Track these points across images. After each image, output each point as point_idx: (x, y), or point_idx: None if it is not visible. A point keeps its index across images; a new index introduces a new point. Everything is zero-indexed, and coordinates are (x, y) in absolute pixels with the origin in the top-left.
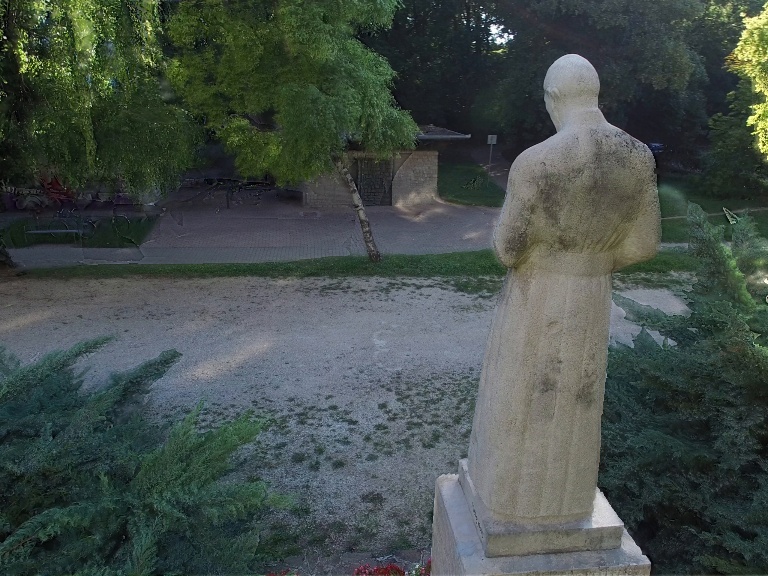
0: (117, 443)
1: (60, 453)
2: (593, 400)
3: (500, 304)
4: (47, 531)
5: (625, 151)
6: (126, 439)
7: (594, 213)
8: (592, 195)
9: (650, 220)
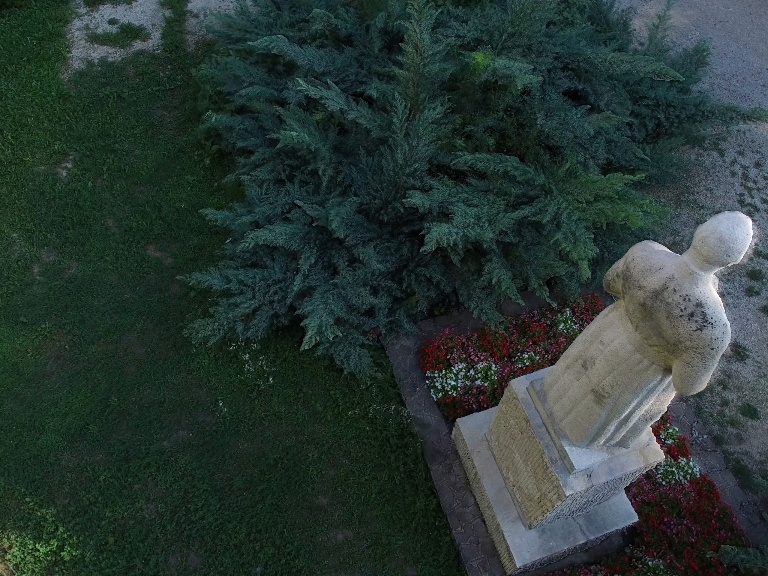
0: (648, 146)
1: (549, 132)
2: (601, 404)
3: None
4: (497, 166)
5: (676, 311)
6: (658, 148)
7: (642, 319)
8: (641, 308)
9: (680, 369)
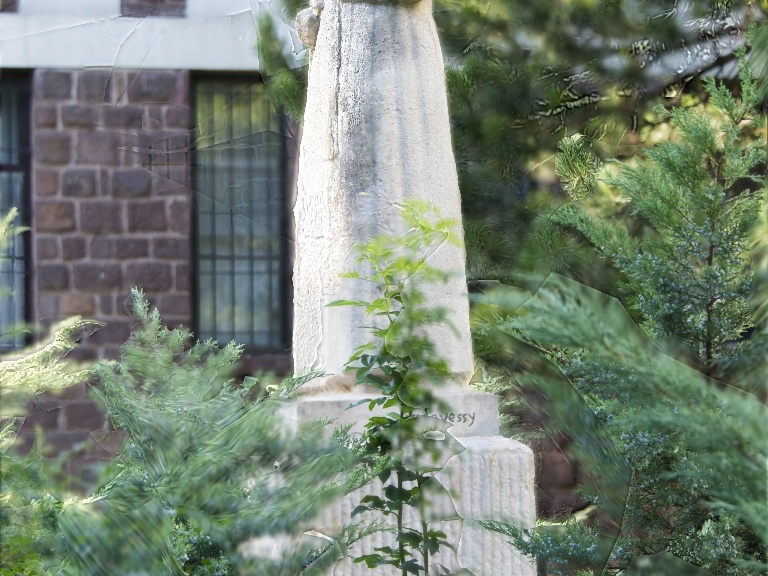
0: None
1: None
2: None
3: (404, 61)
4: None
5: None
6: None
7: None
8: None
9: None
